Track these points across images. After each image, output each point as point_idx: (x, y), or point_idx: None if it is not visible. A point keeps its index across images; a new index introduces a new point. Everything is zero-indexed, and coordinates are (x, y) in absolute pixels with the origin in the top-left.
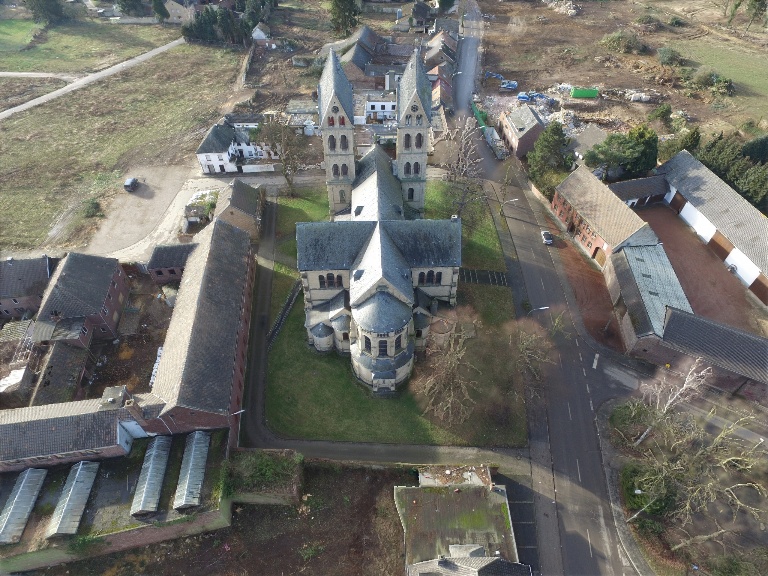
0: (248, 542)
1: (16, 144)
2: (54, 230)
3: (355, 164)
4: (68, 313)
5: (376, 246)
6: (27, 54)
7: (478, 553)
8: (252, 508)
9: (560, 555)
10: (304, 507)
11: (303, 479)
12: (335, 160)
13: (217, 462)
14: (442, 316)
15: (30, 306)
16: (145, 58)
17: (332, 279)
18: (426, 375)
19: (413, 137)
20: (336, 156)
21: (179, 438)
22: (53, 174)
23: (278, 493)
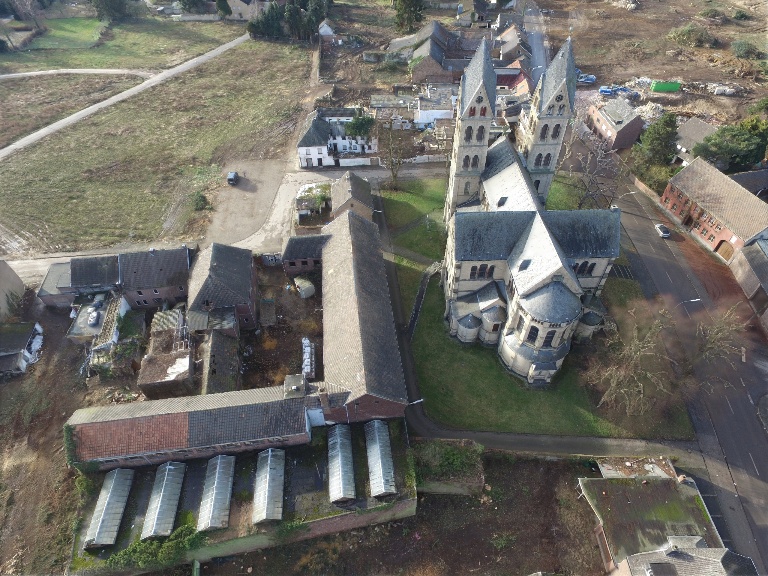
0: (437, 531)
1: (109, 139)
2: (167, 223)
3: None
4: (219, 303)
5: (543, 236)
6: (98, 51)
7: (701, 544)
8: (433, 498)
9: (756, 549)
10: (485, 497)
11: None
12: (468, 151)
13: (402, 451)
14: (592, 308)
15: (168, 296)
16: (215, 54)
17: (484, 270)
18: (602, 366)
19: (551, 128)
20: (470, 147)
21: (356, 427)
22: (153, 168)
23: (467, 482)
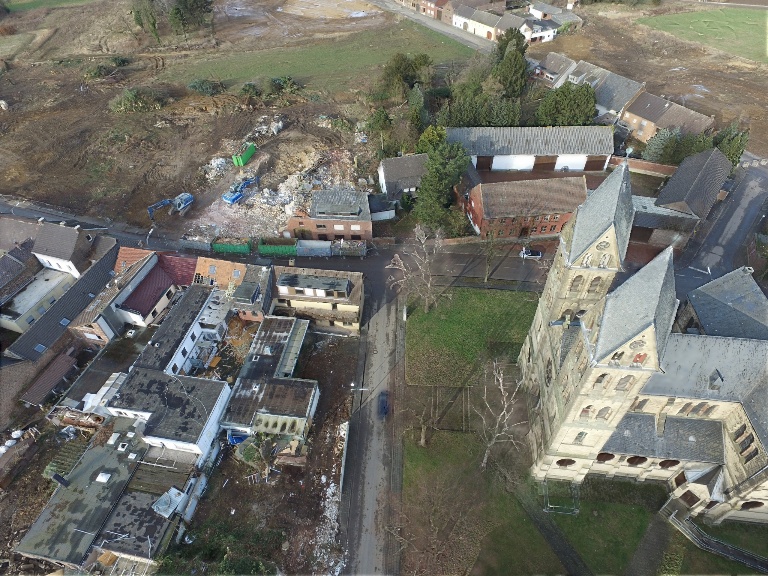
0: None
1: None
2: None
3: None
4: None
5: None
6: None
7: None
8: None
9: None
10: None
11: None
12: None
13: None
14: None
15: None
16: None
17: None
18: None
19: None
20: None
21: None
22: None
23: None
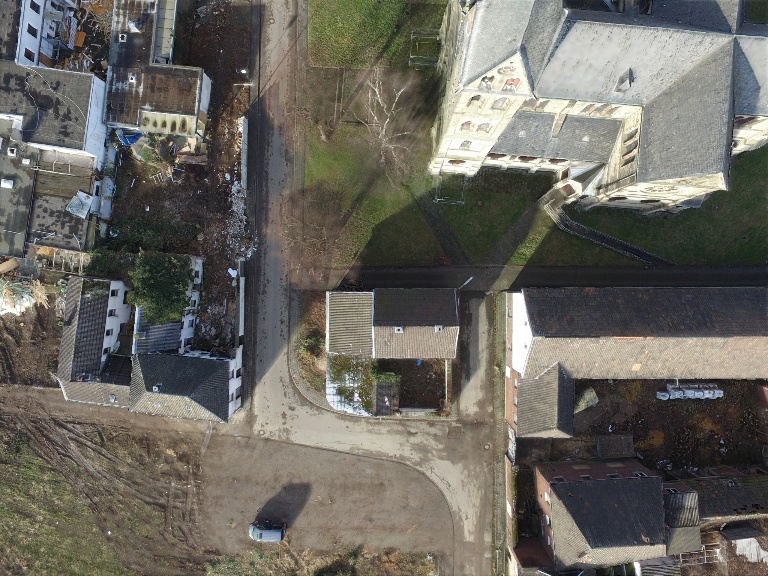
0: None
1: None
2: None
3: None
4: None
5: None
6: None
7: None
8: None
9: None
10: None
11: None
12: None
13: None
14: None
15: None
16: None
17: None
18: None
19: None
20: None
21: None
22: None
23: None
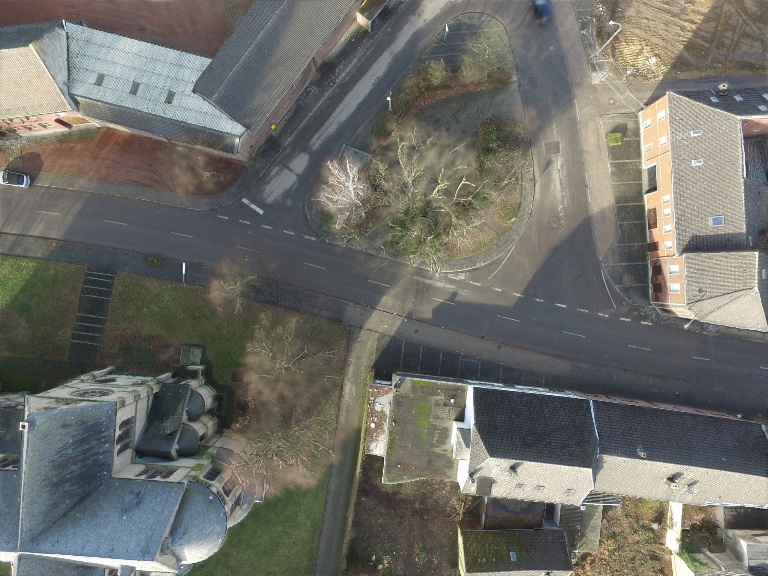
0: None
1: None
2: None
3: None
4: None
5: None
6: None
7: (465, 437)
8: None
9: (450, 331)
10: (384, 562)
11: (360, 567)
12: None
13: None
14: (181, 409)
15: None
16: None
17: None
18: None
19: None
20: None
21: None
22: None
23: None
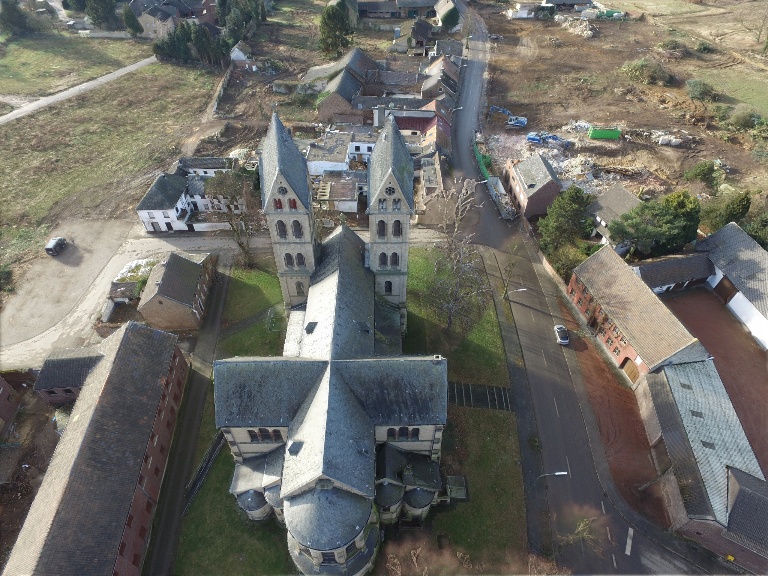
0: None
1: None
2: None
3: (317, 248)
4: None
5: (322, 407)
6: None
7: None
8: None
9: None
10: None
11: None
12: (287, 249)
13: None
14: (419, 483)
15: None
16: (108, 79)
17: (267, 432)
18: None
19: (389, 224)
20: (288, 244)
21: None
22: None
23: None
